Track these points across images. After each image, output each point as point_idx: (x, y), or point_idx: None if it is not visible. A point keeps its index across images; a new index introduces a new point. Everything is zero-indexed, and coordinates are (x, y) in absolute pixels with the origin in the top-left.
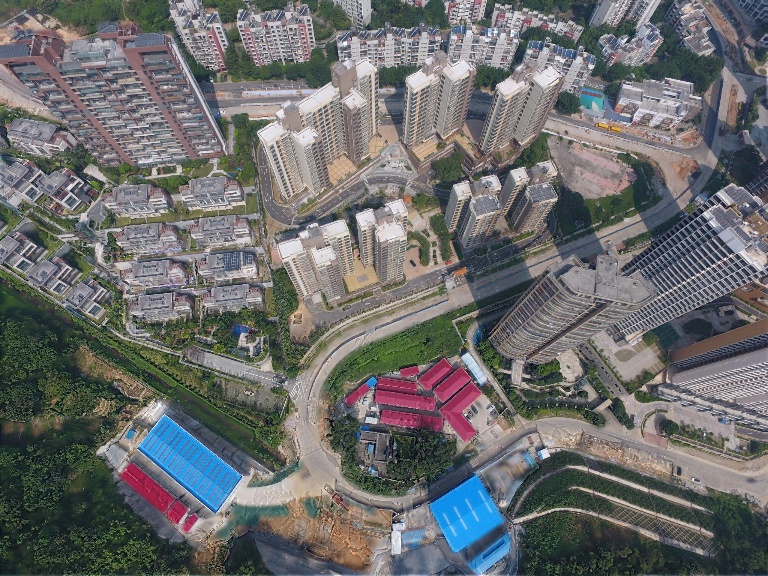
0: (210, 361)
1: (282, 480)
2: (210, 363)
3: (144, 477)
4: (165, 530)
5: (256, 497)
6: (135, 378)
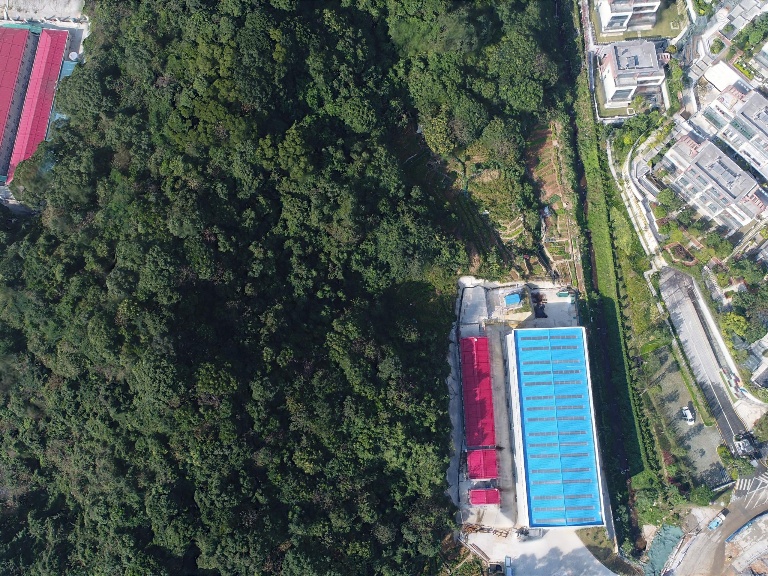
0: (683, 316)
1: (620, 575)
2: (680, 319)
3: (487, 374)
4: (453, 468)
5: (572, 556)
6: (574, 232)
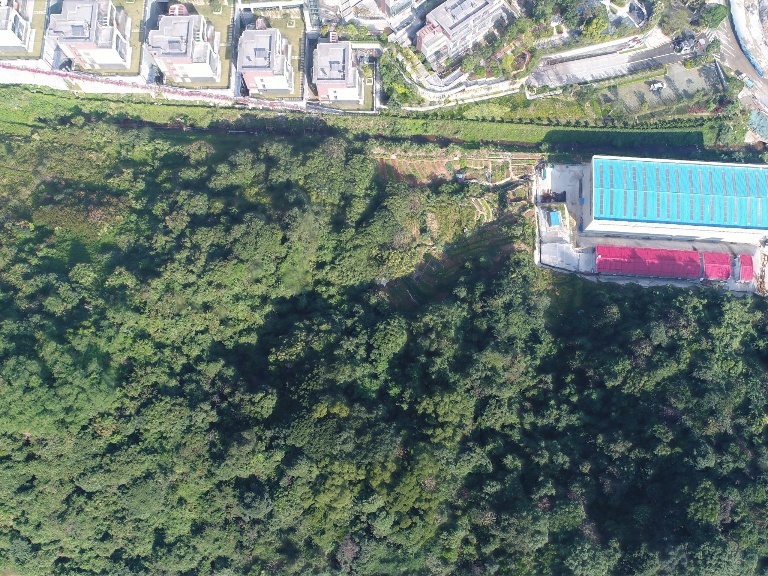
0: (570, 74)
1: None
2: (572, 77)
3: (632, 251)
4: None
5: None
6: (484, 154)
